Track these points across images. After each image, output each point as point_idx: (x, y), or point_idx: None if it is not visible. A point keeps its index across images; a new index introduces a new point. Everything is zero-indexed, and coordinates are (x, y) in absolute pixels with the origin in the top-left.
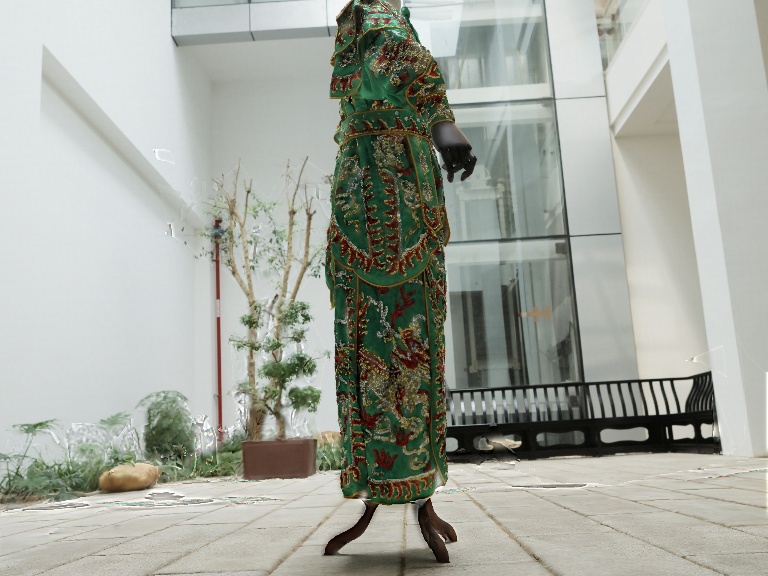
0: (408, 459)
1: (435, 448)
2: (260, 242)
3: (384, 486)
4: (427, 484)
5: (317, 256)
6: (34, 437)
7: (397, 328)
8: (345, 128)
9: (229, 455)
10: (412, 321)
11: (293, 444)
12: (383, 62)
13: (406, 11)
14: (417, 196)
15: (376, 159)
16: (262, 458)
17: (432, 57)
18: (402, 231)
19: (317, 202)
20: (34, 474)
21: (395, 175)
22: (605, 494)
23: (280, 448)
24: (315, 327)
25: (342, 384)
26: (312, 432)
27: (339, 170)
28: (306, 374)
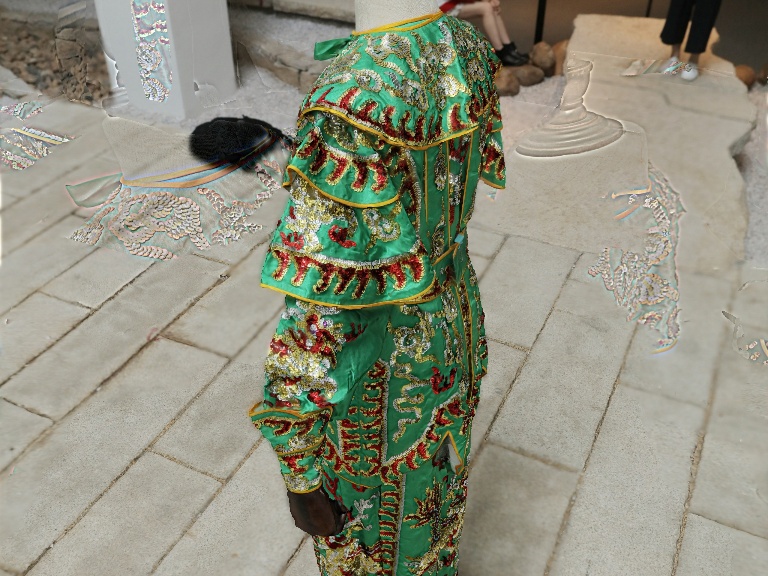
0: None
1: None
2: None
3: None
4: None
5: None
6: None
7: None
8: None
9: None
10: None
11: None
12: None
13: None
14: None
15: None
16: None
17: None
18: None
19: None
20: None
21: None
22: None
23: None
24: None
25: None
26: None
27: None
28: None
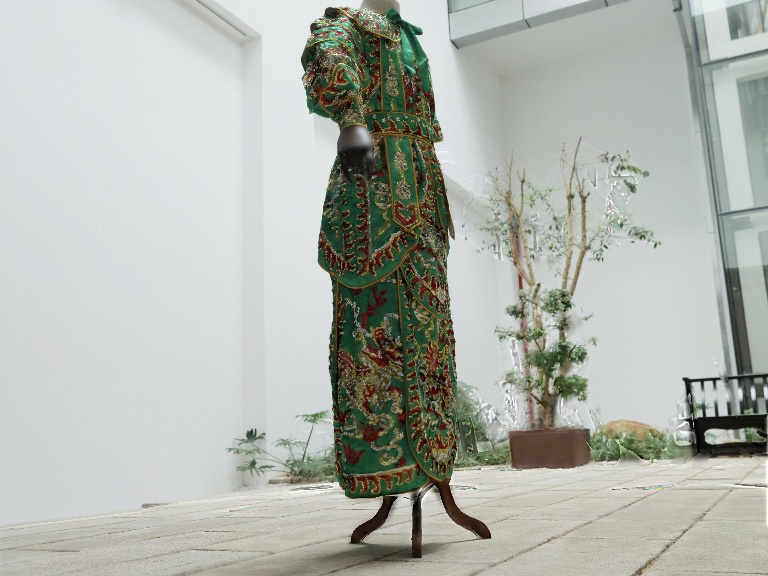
0: (377, 455)
1: (412, 444)
2: (539, 230)
3: (349, 480)
4: (401, 479)
5: (596, 239)
6: (317, 426)
7: (369, 327)
8: None
9: (488, 444)
10: (383, 320)
11: (558, 434)
12: (309, 77)
13: (391, 12)
14: (389, 196)
15: None
16: (528, 447)
17: (337, 65)
18: (371, 233)
19: (589, 183)
20: (316, 459)
21: None
22: None
23: (546, 437)
24: (577, 314)
25: None
26: (583, 421)
27: None
28: (577, 362)
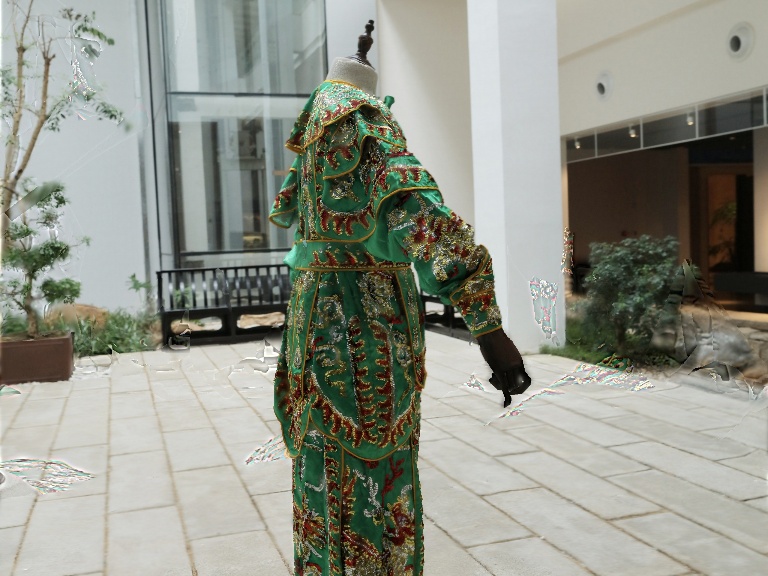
0: None
1: None
2: None
3: None
4: None
5: (56, 108)
6: None
7: (386, 505)
8: (317, 252)
9: None
10: (400, 494)
11: (51, 344)
12: (421, 243)
13: None
14: (408, 349)
15: (365, 306)
16: (14, 360)
17: None
18: (395, 397)
19: (57, 45)
20: None
21: (387, 328)
22: (440, 470)
23: (35, 349)
24: (71, 211)
25: (314, 556)
26: (69, 325)
27: (312, 308)
28: (58, 258)
